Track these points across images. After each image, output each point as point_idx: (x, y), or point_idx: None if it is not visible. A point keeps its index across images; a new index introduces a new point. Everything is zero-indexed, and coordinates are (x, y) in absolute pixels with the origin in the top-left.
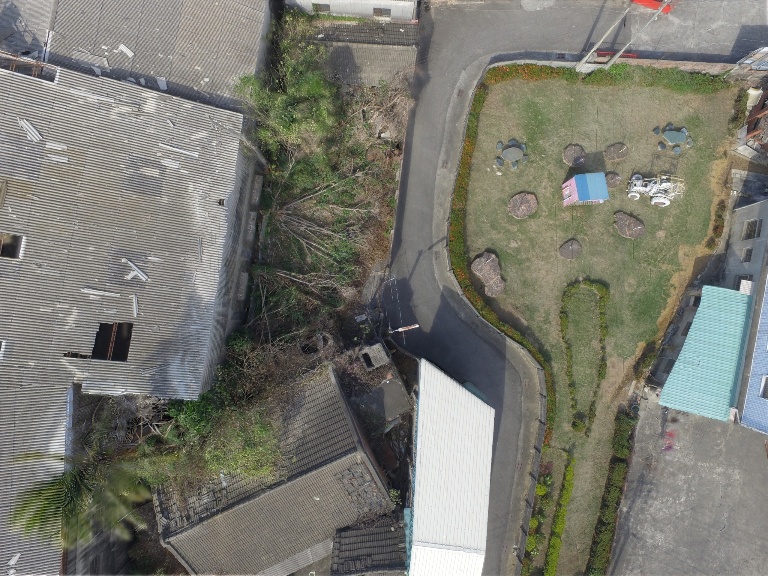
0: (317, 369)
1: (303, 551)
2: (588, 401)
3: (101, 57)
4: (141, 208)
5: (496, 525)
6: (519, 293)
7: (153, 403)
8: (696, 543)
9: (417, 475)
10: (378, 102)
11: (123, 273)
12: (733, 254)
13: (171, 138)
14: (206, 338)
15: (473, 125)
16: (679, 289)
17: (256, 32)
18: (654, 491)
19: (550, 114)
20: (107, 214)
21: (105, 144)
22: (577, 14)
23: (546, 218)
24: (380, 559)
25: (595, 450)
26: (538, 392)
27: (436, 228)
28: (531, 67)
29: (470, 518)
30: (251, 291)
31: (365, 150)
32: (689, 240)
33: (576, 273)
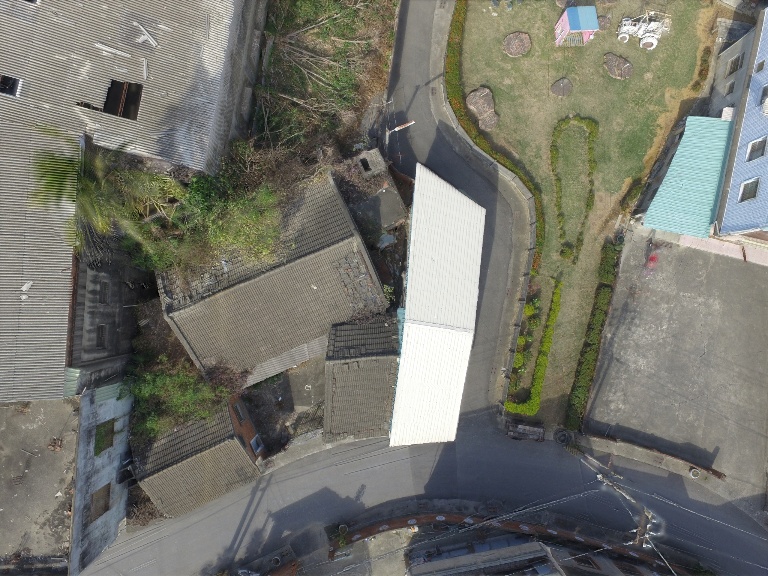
0: (316, 174)
1: (300, 347)
2: (576, 232)
3: None
4: None
5: (486, 348)
6: (512, 128)
7: (159, 185)
8: (677, 368)
9: (410, 263)
10: None
11: (134, 36)
12: (717, 94)
13: None
14: (212, 112)
15: None
16: (665, 129)
17: None
18: (637, 318)
19: None
20: None
21: None
22: None
23: (539, 58)
24: (374, 348)
25: (582, 279)
26: (528, 224)
27: (433, 65)
28: None
29: (460, 302)
30: (254, 112)
31: None
32: (675, 83)
33: (567, 111)
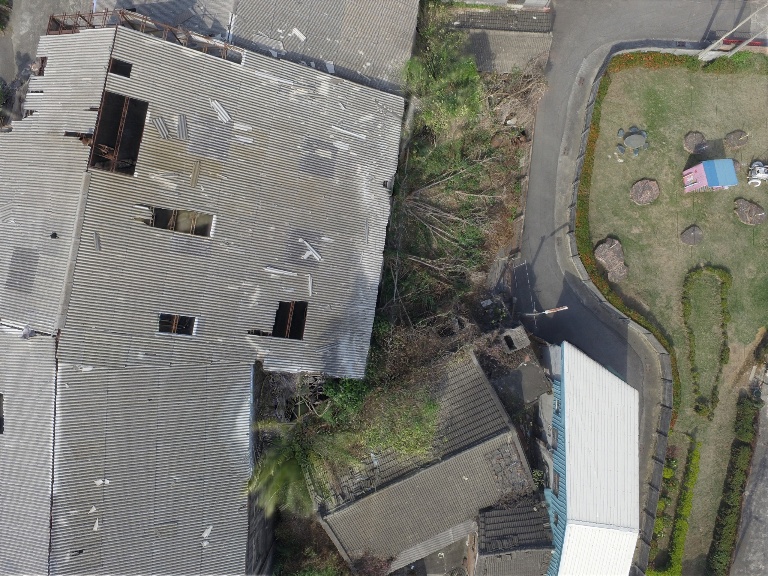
0: (458, 351)
1: (445, 531)
2: (710, 386)
3: (277, 40)
4: (316, 189)
5: None
6: (641, 279)
7: (310, 383)
8: None
9: (567, 455)
10: (507, 89)
11: (300, 253)
12: None
13: (342, 120)
14: (371, 318)
15: (598, 112)
16: None
17: (411, 17)
18: None
19: (670, 102)
20: (286, 194)
21: (285, 126)
22: (697, 3)
23: (667, 205)
24: (526, 538)
25: (717, 434)
26: (660, 377)
27: (558, 214)
28: (655, 55)
29: (622, 497)
30: (383, 275)
31: (490, 137)
32: None
33: (697, 259)
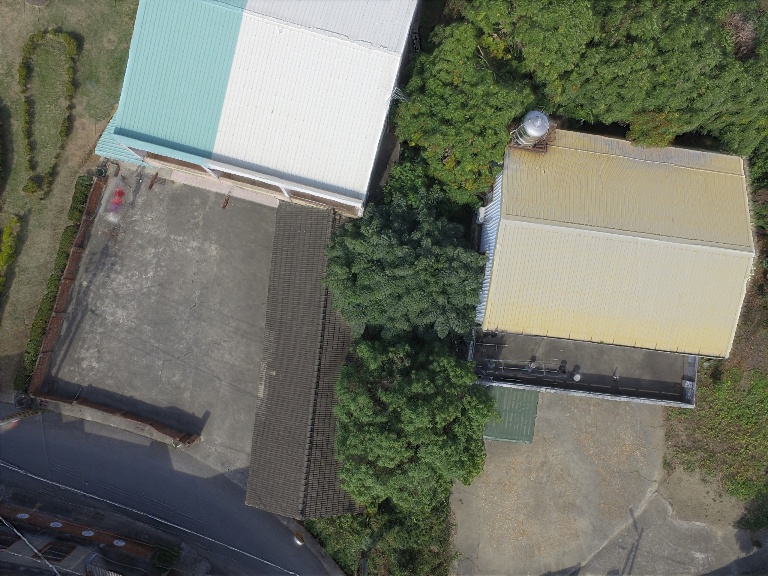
0: None
1: None
2: (50, 164)
3: None
4: None
5: None
6: None
7: None
8: (162, 322)
9: None
10: None
11: None
12: None
13: None
14: None
15: None
16: None
17: None
18: (119, 264)
19: None
20: None
21: None
22: None
23: None
24: None
25: (56, 218)
26: None
27: None
28: None
29: None
30: None
31: None
32: None
33: (46, 23)
